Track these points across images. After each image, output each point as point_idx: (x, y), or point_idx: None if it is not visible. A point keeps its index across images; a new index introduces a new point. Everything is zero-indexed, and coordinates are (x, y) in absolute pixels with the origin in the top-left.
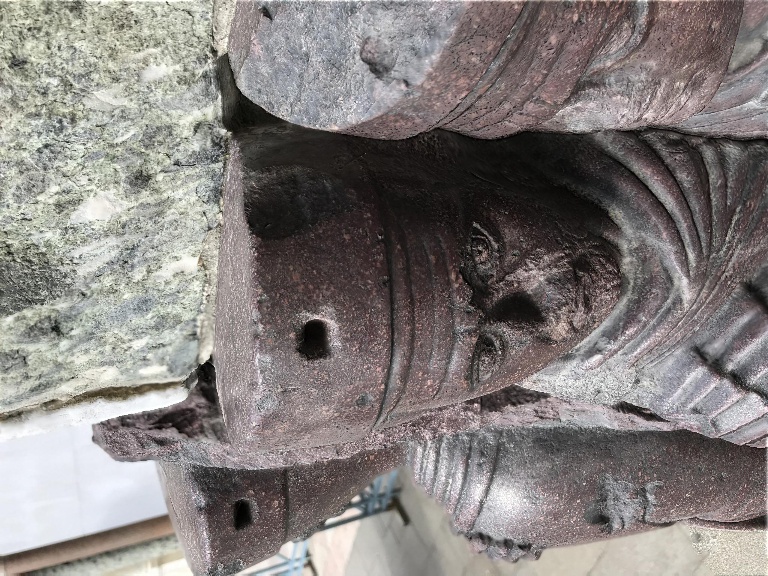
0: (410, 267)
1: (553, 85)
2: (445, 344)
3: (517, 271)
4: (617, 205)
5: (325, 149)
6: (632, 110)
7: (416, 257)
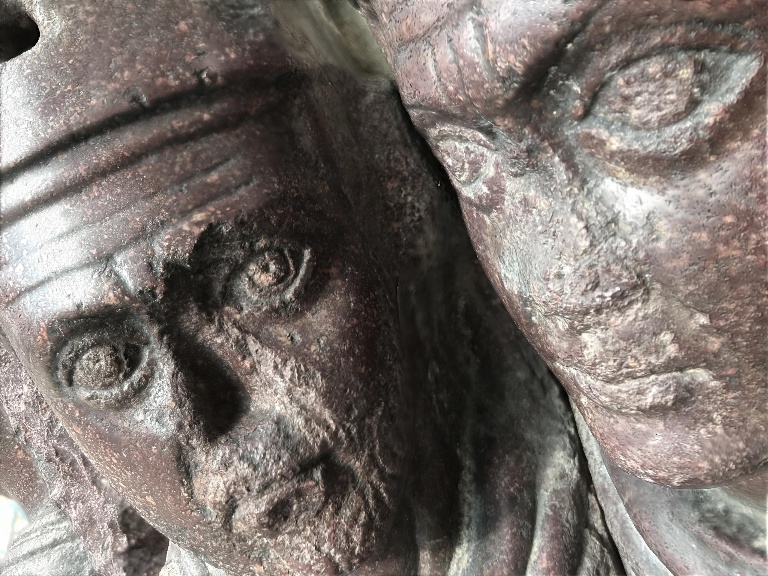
0: (183, 144)
1: (514, 7)
2: (83, 250)
3: (268, 351)
4: (476, 548)
5: (316, 36)
6: (579, 277)
7: (204, 150)
